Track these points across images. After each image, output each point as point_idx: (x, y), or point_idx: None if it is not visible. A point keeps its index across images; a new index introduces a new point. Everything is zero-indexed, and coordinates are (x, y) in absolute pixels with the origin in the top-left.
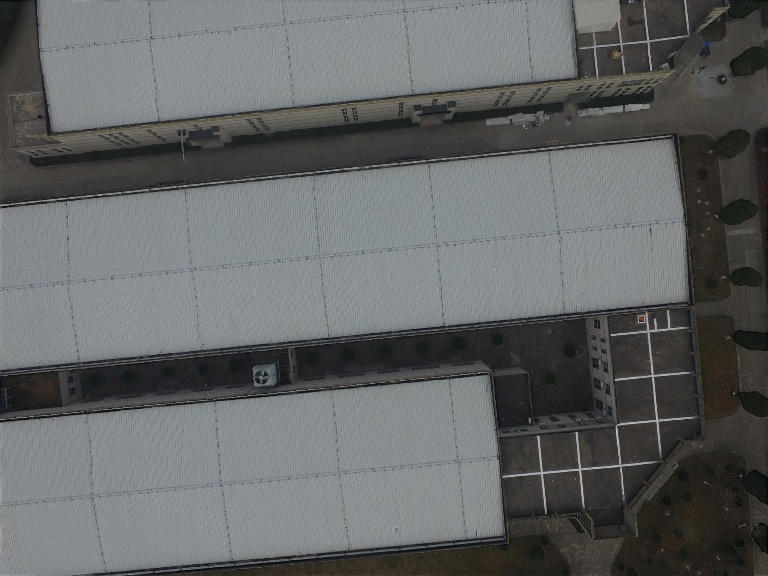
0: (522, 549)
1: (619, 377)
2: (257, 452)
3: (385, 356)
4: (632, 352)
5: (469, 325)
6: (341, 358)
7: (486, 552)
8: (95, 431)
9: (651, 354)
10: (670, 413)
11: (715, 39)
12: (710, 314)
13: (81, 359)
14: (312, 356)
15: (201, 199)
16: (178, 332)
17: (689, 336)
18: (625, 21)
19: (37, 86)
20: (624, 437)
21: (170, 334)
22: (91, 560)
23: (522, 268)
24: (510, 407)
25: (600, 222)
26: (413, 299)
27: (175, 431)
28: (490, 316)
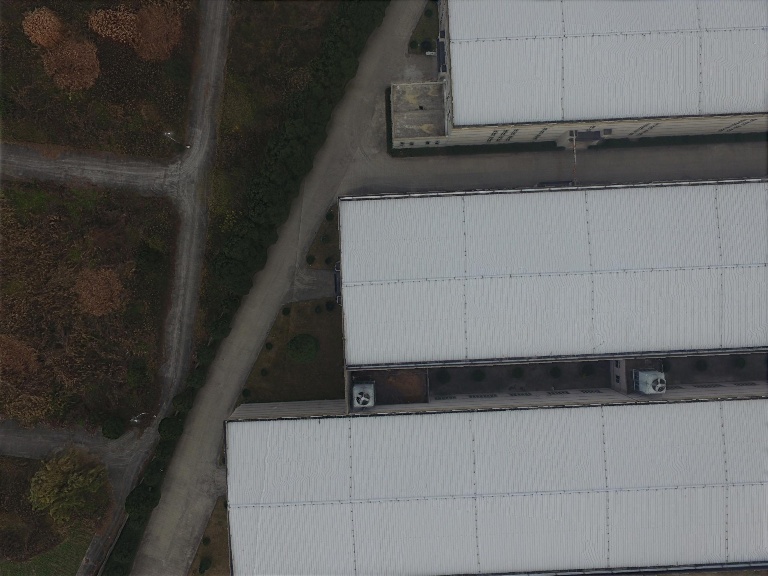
0: None
1: None
2: (644, 459)
3: (737, 368)
4: None
5: None
6: (693, 368)
7: None
8: (479, 430)
9: None
10: None
11: None
12: None
13: (469, 356)
14: (668, 365)
15: (601, 202)
16: (587, 335)
17: None
18: None
19: (398, 76)
20: None
21: (582, 337)
22: (465, 560)
23: None
24: None
25: None
26: None
27: (561, 434)
28: None
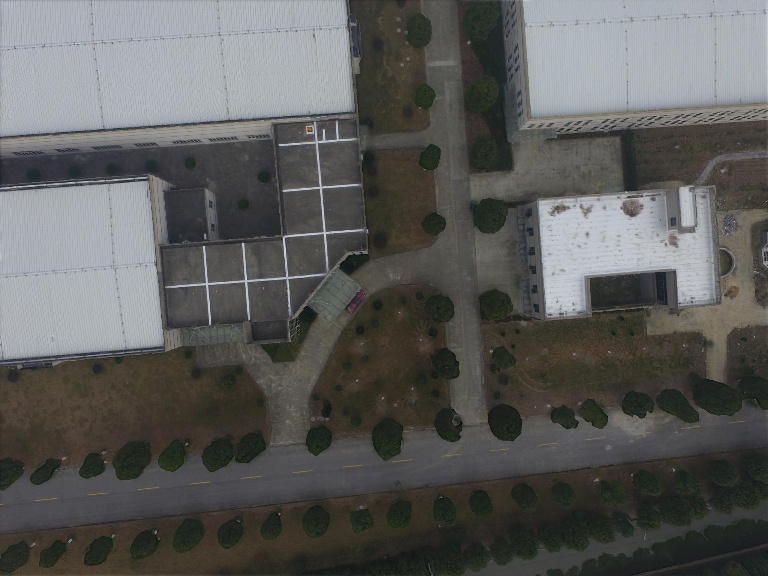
0: (216, 379)
1: (287, 188)
2: None
3: (74, 178)
4: (300, 163)
5: (130, 129)
6: (28, 179)
7: (180, 382)
8: None
9: (319, 165)
10: (338, 225)
11: None
12: (409, 145)
13: None
14: None
15: None
16: None
17: (357, 148)
18: None
19: None
20: (291, 249)
21: None
22: None
23: (178, 67)
24: (187, 223)
25: (263, 25)
26: (65, 96)
27: None
28: (149, 119)
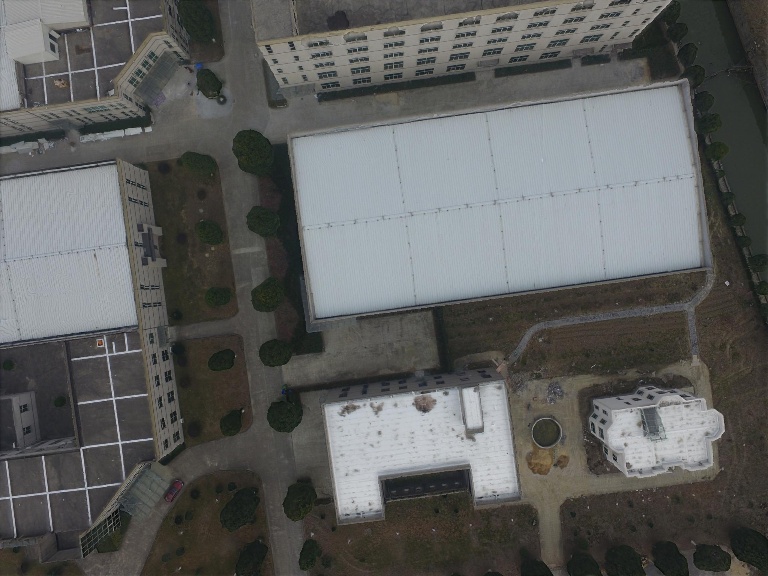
0: (46, 570)
1: (82, 401)
2: None
3: None
4: (93, 376)
5: None
6: None
7: (12, 574)
8: None
9: (111, 377)
10: (132, 435)
11: (213, 60)
12: (219, 333)
13: None
14: None
15: None
16: None
17: None
18: (73, 50)
19: None
20: (89, 460)
21: None
22: None
23: None
24: None
25: (45, 249)
26: None
27: None
28: None
